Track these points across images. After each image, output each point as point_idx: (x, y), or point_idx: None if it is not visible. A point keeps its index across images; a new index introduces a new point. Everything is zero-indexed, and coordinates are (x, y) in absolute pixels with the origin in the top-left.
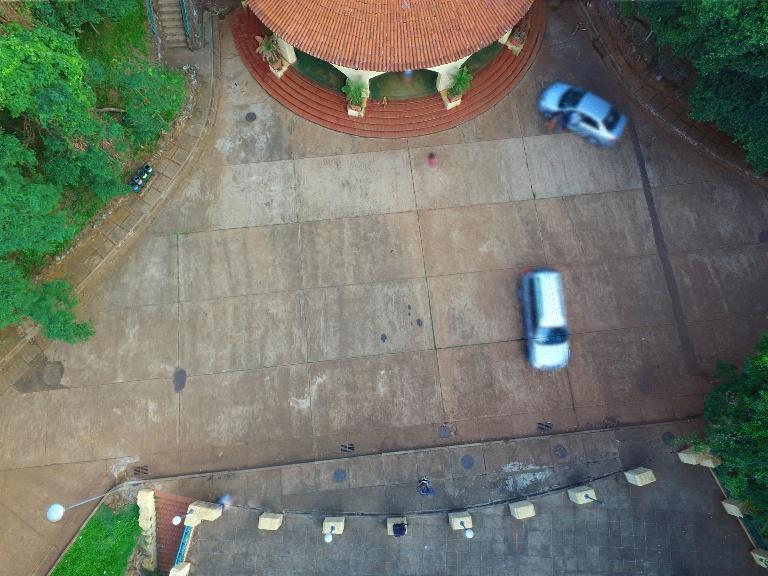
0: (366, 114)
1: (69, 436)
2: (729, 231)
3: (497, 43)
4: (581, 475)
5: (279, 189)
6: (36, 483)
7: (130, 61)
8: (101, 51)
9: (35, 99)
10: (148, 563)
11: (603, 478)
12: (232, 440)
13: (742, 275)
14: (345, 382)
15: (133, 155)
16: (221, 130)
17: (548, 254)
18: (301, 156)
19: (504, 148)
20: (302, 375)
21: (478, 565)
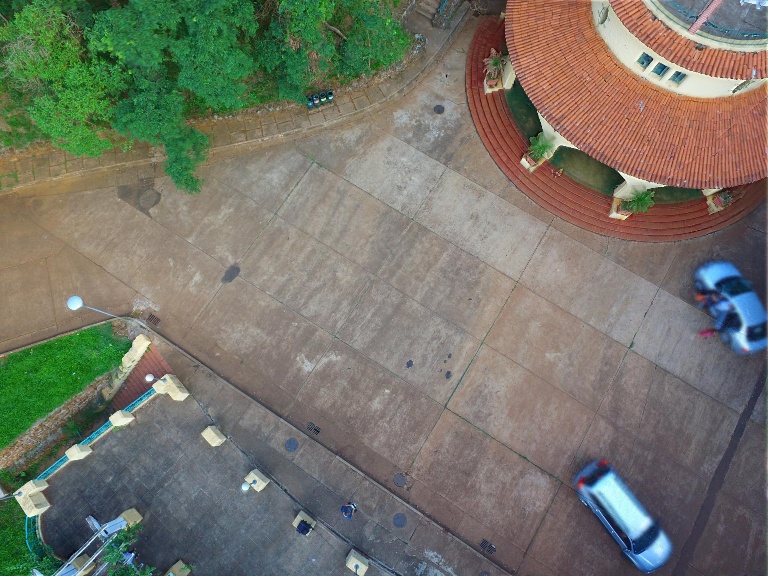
0: (535, 172)
1: (125, 254)
2: None
3: (699, 191)
4: None
5: (418, 182)
6: (79, 270)
7: (379, 3)
8: None
9: None
10: (107, 392)
11: None
12: (234, 350)
13: None
14: (352, 375)
15: (327, 77)
16: (408, 103)
17: (605, 404)
18: (455, 168)
19: (635, 285)
20: (323, 343)
21: None
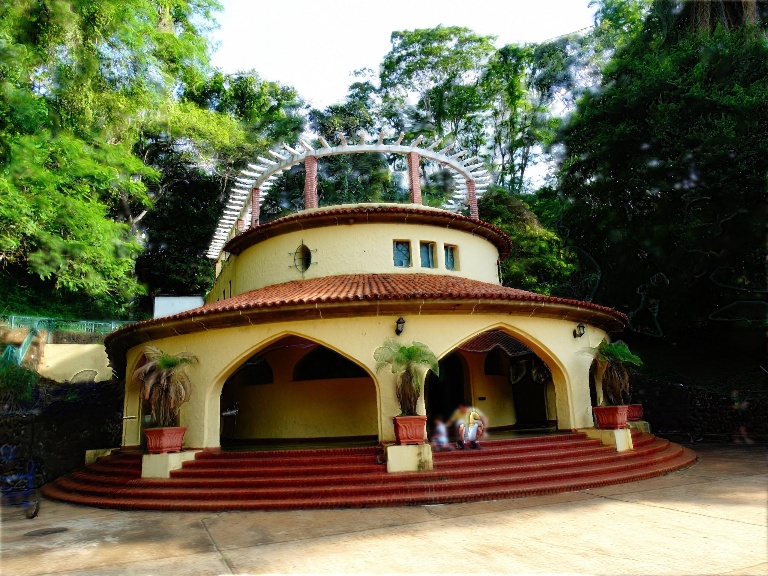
0: (437, 461)
1: None
2: None
3: None
4: None
5: None
6: None
7: None
8: None
9: None
10: None
11: None
12: None
13: None
14: None
15: None
16: None
17: None
18: (252, 543)
19: None
20: None
21: None
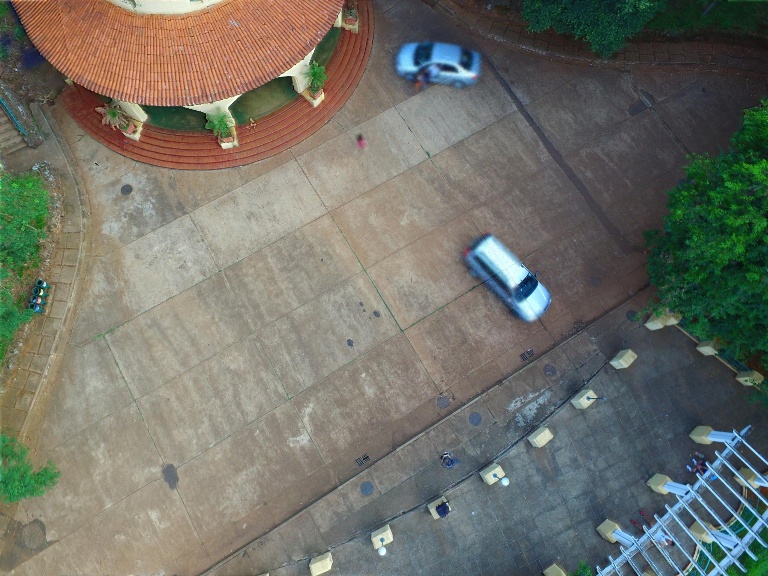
0: (240, 142)
1: None
2: (603, 117)
3: (334, 29)
4: (576, 383)
5: (187, 248)
6: None
7: None
8: None
9: None
10: None
11: (595, 376)
12: (249, 507)
13: (630, 150)
14: (333, 400)
15: (19, 277)
16: (101, 215)
17: (463, 202)
18: (194, 207)
19: (382, 122)
20: (289, 413)
21: (525, 505)
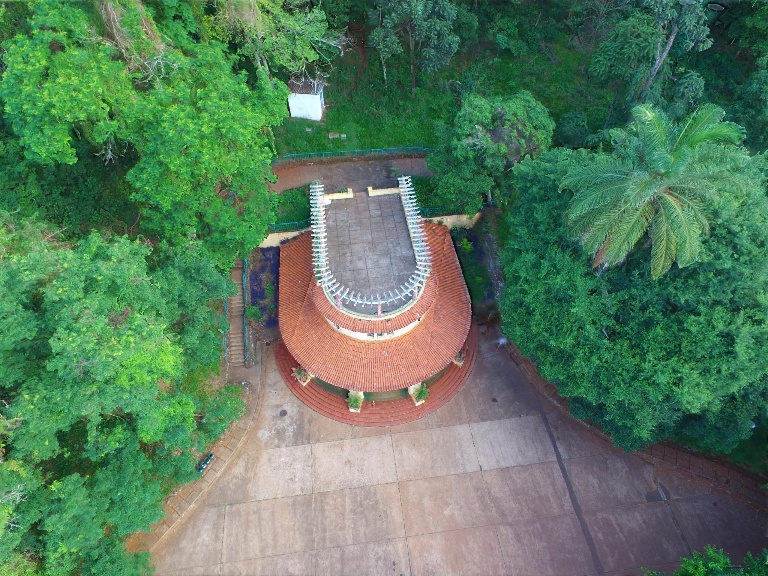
0: (361, 411)
1: None
2: (623, 493)
3: None
4: None
5: (300, 467)
6: None
7: (209, 381)
8: (192, 377)
9: (166, 435)
10: None
11: None
12: None
13: (639, 530)
14: None
15: None
16: (262, 423)
17: (495, 515)
18: (316, 441)
19: (457, 432)
20: None
21: None
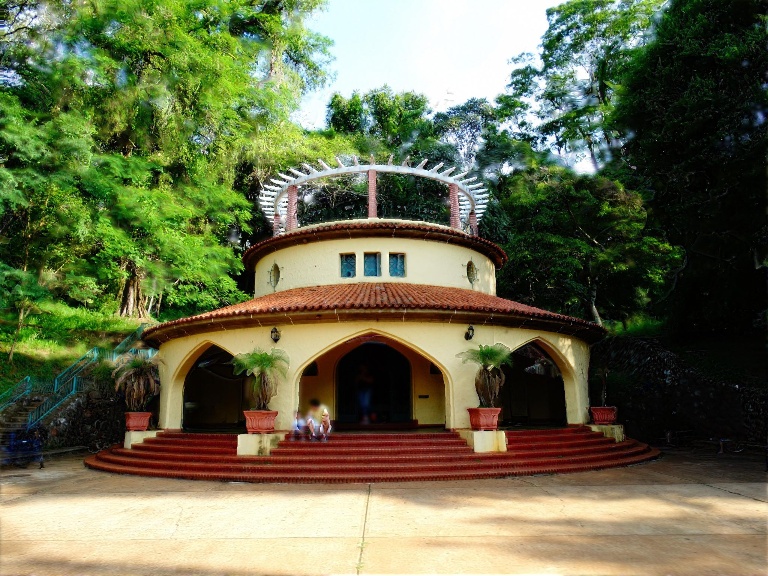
0: (277, 448)
1: None
2: None
3: (567, 426)
4: None
5: None
6: None
7: None
8: None
9: None
10: None
11: None
12: None
13: None
14: None
15: None
16: None
17: None
18: (61, 492)
19: (658, 489)
20: None
21: None
